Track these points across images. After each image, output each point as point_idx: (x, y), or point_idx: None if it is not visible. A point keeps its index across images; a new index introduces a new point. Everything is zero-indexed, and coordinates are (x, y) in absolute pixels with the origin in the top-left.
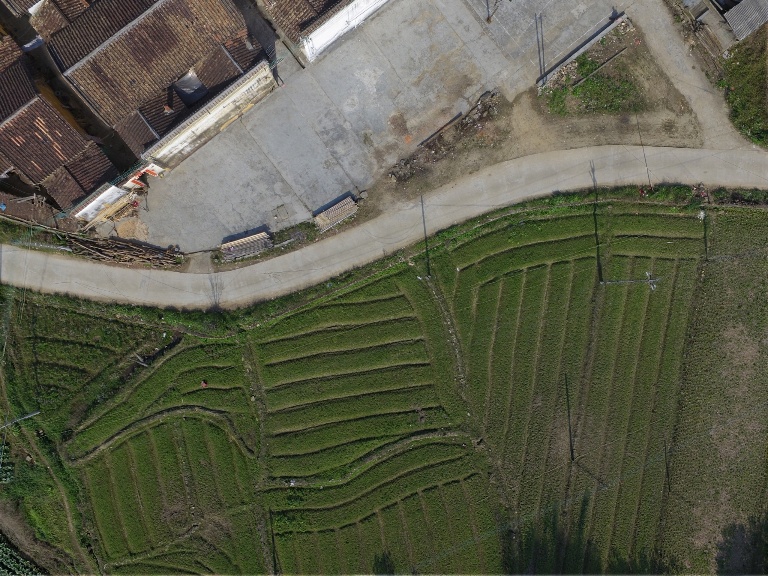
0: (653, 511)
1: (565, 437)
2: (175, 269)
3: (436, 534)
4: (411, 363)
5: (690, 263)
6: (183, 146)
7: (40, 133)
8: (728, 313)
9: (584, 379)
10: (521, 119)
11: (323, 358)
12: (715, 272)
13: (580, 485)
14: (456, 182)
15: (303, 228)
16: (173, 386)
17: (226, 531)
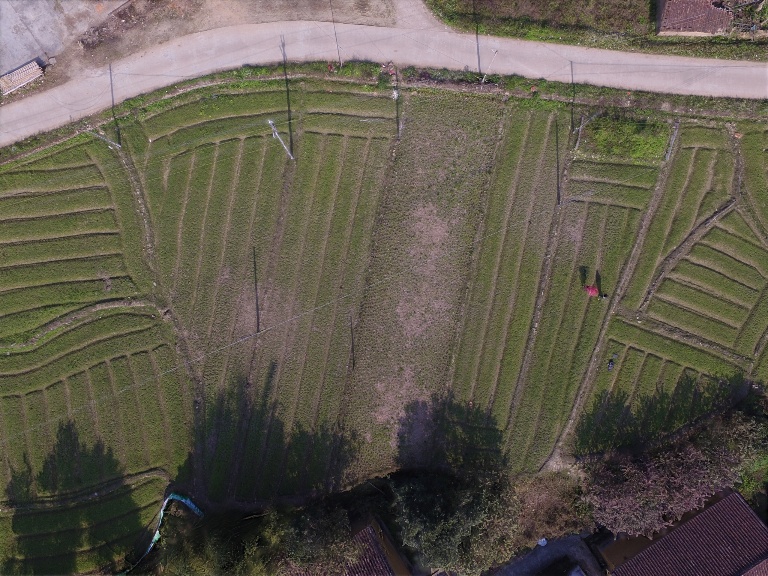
0: (337, 385)
1: (252, 310)
2: None
3: (122, 403)
4: (100, 232)
5: (381, 142)
6: None
7: None
8: (418, 193)
9: (272, 253)
10: None
11: (10, 223)
12: (407, 152)
13: (265, 358)
14: (145, 51)
15: None
16: None
17: None
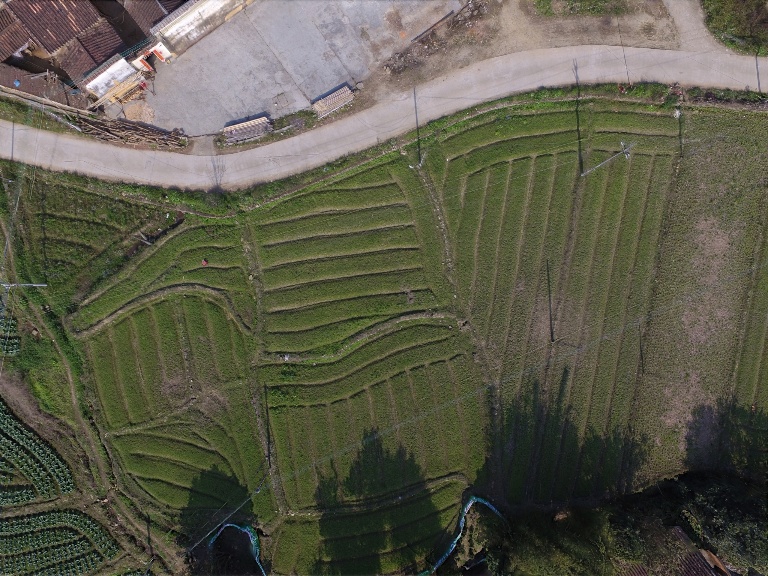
0: (627, 391)
1: (546, 320)
2: (179, 151)
3: (422, 410)
4: (402, 247)
5: (666, 159)
6: (190, 29)
7: (56, 2)
8: (700, 207)
9: (564, 266)
10: (509, 19)
11: (318, 240)
12: (689, 168)
13: (559, 366)
14: (447, 76)
15: (302, 115)
16: (175, 264)
17: (223, 405)
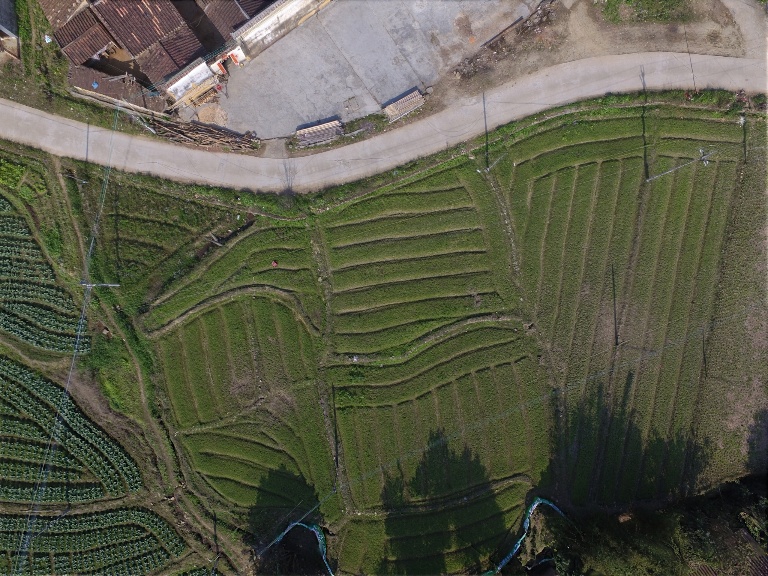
0: (690, 395)
1: (610, 324)
2: (251, 154)
3: (488, 412)
4: (469, 251)
5: (730, 165)
6: (266, 33)
7: (142, 6)
8: (764, 213)
9: (629, 270)
10: (577, 25)
11: (387, 243)
12: (753, 174)
13: (623, 369)
14: (516, 81)
15: (372, 119)
16: (245, 265)
17: (290, 405)
